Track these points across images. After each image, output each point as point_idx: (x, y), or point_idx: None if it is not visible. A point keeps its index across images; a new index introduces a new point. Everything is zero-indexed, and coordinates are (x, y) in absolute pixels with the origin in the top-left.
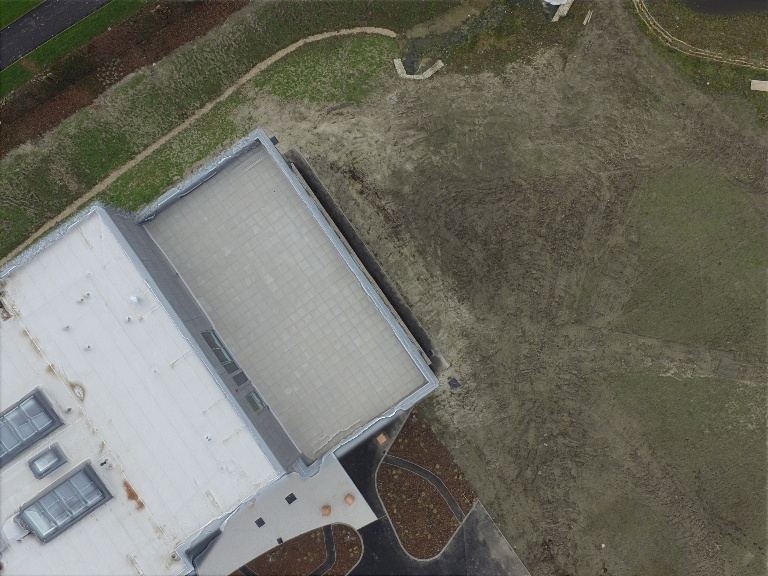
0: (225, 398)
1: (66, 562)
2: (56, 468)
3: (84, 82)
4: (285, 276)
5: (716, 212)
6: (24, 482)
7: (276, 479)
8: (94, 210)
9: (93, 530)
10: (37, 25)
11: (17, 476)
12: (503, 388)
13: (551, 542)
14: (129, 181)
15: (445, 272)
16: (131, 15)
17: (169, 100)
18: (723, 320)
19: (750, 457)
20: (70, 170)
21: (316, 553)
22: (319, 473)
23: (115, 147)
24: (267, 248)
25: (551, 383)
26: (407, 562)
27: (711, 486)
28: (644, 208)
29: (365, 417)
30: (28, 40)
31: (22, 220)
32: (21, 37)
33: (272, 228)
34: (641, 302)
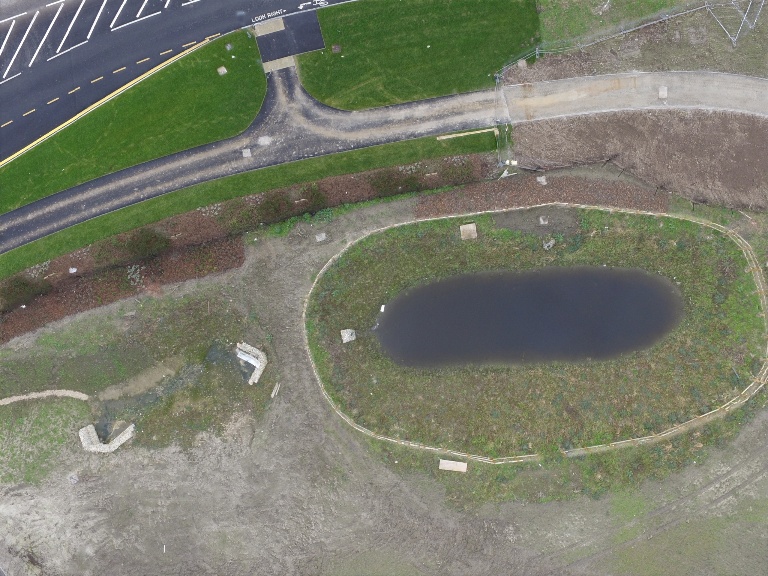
0: None
1: None
2: None
3: None
4: None
5: None
6: None
7: None
8: None
9: None
10: None
11: None
12: None
13: None
14: None
15: None
16: None
17: None
18: None
19: None
20: None
21: None
22: None
23: None
24: None
25: None
26: None
27: None
28: None
29: None
30: None
31: None
32: None
33: None
34: None
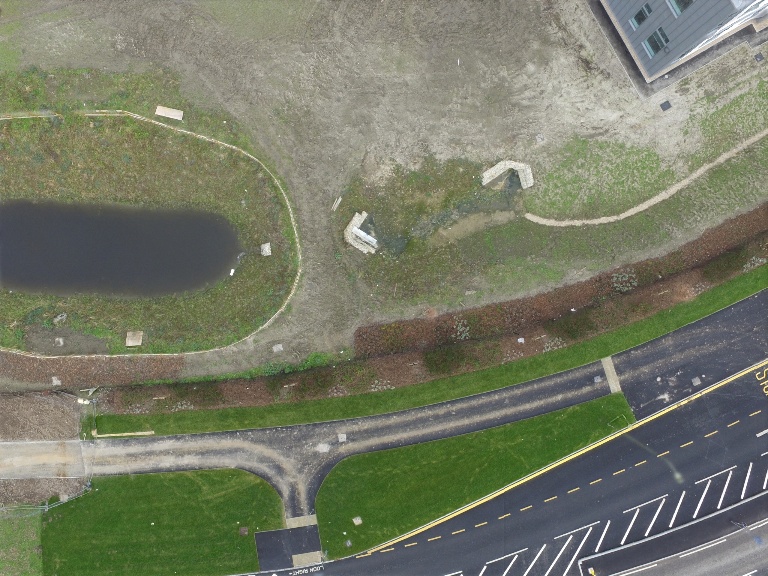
0: None
1: None
2: None
3: None
4: None
5: None
6: None
7: None
8: None
9: None
10: None
11: None
12: None
13: None
14: None
15: None
16: None
17: (764, 164)
18: None
19: None
20: None
21: None
22: None
23: None
24: None
25: None
26: None
27: None
28: (301, 0)
29: None
30: None
31: None
32: None
33: None
34: None
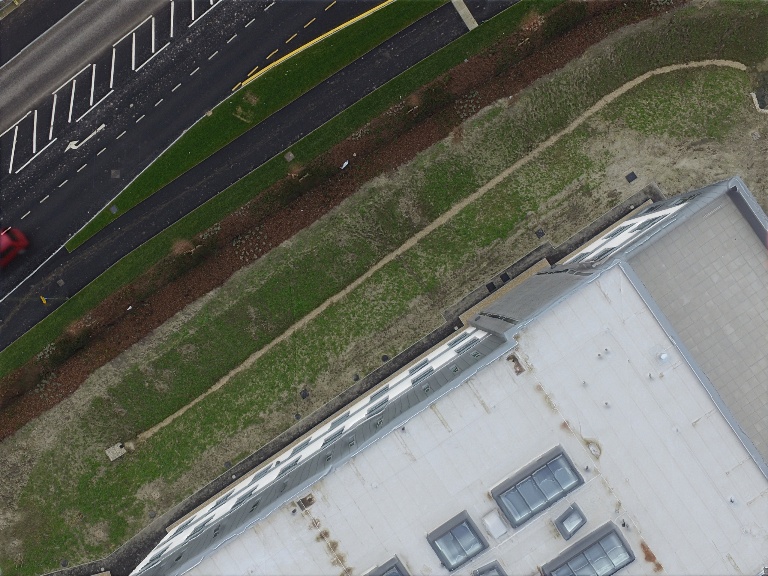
0: (750, 459)
1: None
2: (578, 528)
3: (441, 115)
4: (746, 326)
5: None
6: (540, 541)
7: None
8: (617, 263)
9: None
10: (391, 56)
11: (532, 535)
12: None
13: None
14: (475, 215)
15: None
16: (490, 47)
17: (518, 133)
18: None
19: None
20: (417, 203)
21: None
22: None
23: (461, 180)
24: (727, 297)
25: None
26: None
27: None
28: None
29: None
30: (382, 71)
31: (366, 253)
32: (375, 68)
33: (732, 277)
34: None
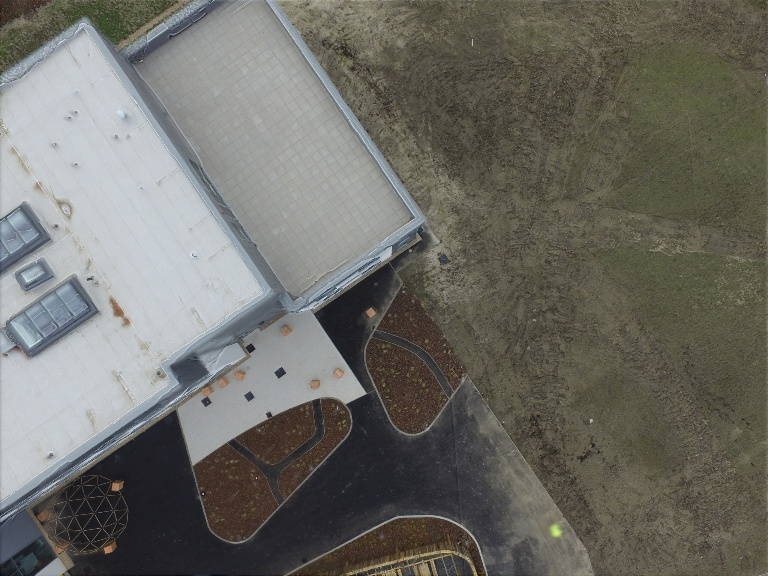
0: (211, 215)
1: (52, 377)
2: (43, 282)
3: None
4: (273, 117)
5: (707, 88)
6: (11, 297)
7: (261, 295)
8: (82, 27)
9: (79, 346)
10: None
11: (4, 291)
12: (493, 264)
13: (539, 417)
14: None
15: (436, 148)
16: None
17: None
18: (713, 196)
19: (739, 333)
20: None
21: (305, 426)
22: (309, 348)
23: (108, 25)
24: (256, 89)
25: (541, 259)
26: (395, 436)
27: (699, 362)
28: (635, 84)
29: (352, 258)
30: None
31: None
32: None
33: (261, 69)
34: (631, 178)
